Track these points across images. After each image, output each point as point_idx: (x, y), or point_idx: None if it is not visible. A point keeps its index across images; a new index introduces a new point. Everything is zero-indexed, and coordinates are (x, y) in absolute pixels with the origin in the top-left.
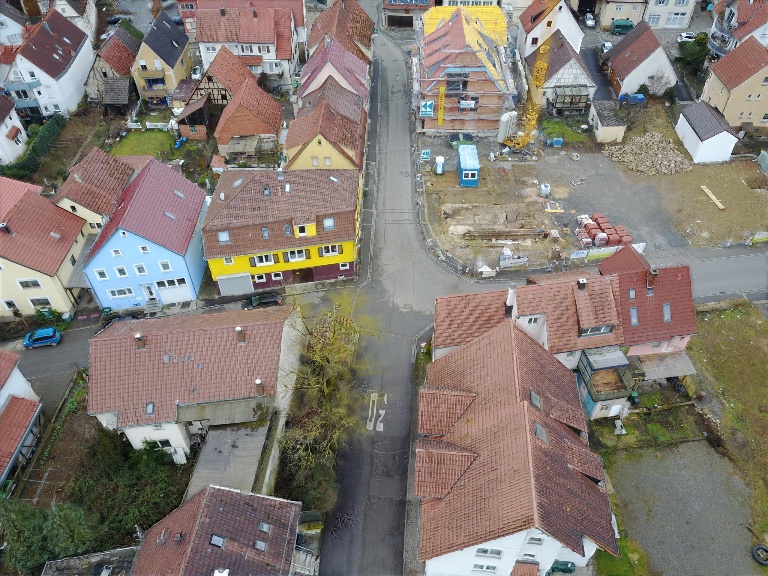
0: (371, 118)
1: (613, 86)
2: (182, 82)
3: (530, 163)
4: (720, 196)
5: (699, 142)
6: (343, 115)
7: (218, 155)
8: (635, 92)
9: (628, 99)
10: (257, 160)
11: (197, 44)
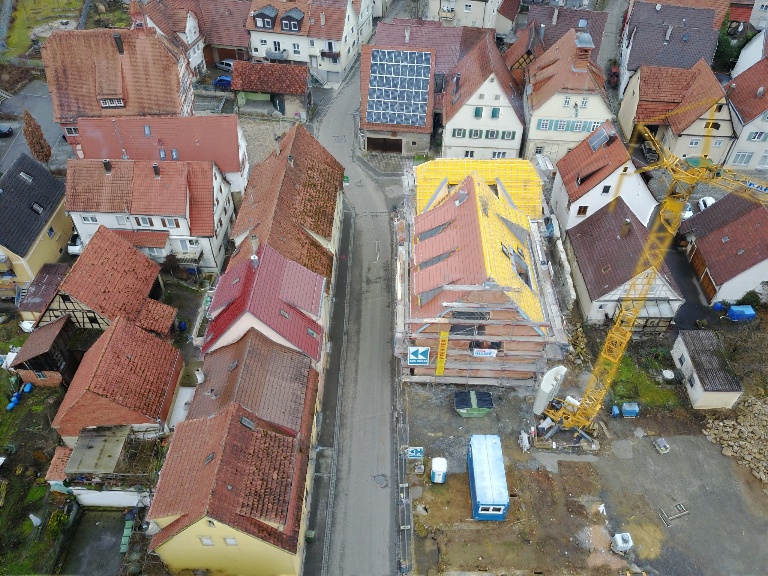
0: (332, 339)
1: (698, 278)
2: (44, 270)
3: (588, 458)
4: None
5: None
6: (268, 421)
7: (64, 448)
8: (737, 299)
9: (727, 311)
10: (120, 481)
11: (68, 213)
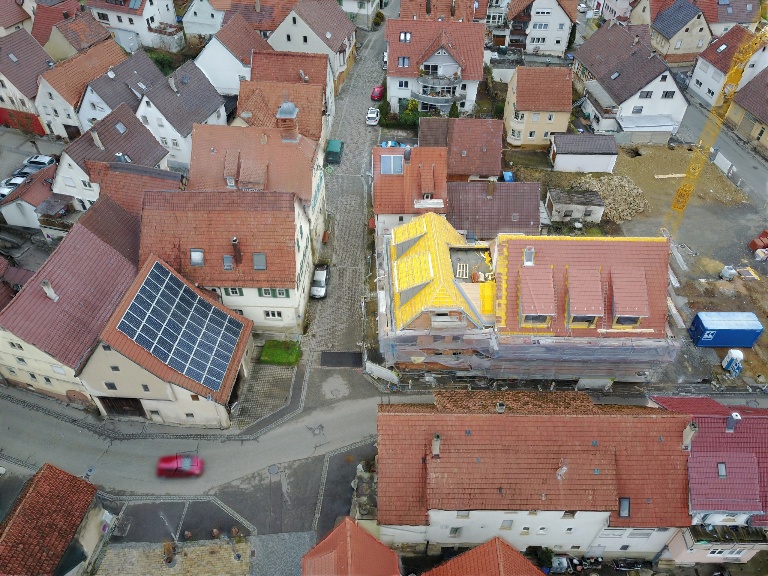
0: None
1: None
2: None
3: None
4: (665, 172)
5: (613, 157)
6: None
7: None
8: None
9: None
10: None
11: None
